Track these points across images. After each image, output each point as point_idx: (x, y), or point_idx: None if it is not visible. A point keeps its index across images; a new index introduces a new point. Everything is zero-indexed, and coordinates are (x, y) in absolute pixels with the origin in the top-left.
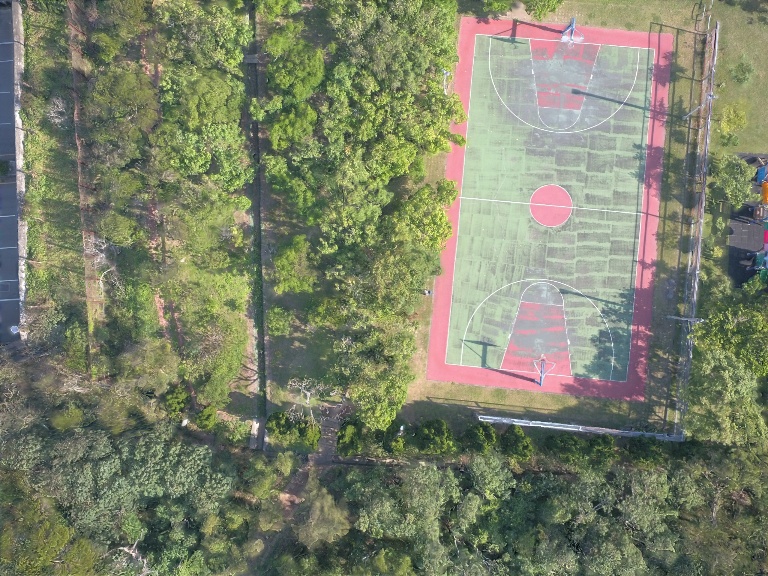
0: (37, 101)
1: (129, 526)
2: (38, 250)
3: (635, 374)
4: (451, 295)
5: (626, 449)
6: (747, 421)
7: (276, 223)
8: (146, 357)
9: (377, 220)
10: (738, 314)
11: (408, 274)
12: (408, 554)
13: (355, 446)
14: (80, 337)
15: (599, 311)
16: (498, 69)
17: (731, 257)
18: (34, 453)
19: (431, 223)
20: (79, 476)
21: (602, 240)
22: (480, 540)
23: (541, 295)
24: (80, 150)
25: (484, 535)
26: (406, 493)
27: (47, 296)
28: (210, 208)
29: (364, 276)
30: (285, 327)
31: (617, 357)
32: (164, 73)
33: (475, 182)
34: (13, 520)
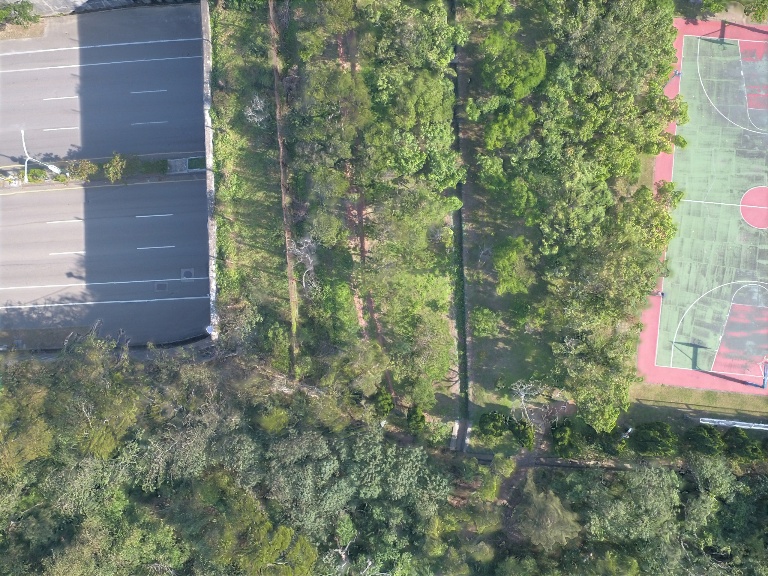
0: (231, 100)
1: (344, 528)
2: (230, 250)
3: None
4: (661, 297)
5: None
6: None
7: (479, 224)
8: (367, 358)
9: None
10: None
11: (643, 276)
12: None
13: (576, 448)
14: (283, 337)
15: None
16: (707, 70)
17: None
18: (249, 454)
19: (658, 224)
20: (299, 477)
21: None
22: (706, 543)
23: (752, 297)
24: (282, 149)
25: (709, 538)
26: (636, 495)
27: (242, 296)
28: (429, 208)
29: (592, 277)
30: (494, 328)
31: None
32: (362, 72)
33: (684, 183)
34: (207, 521)
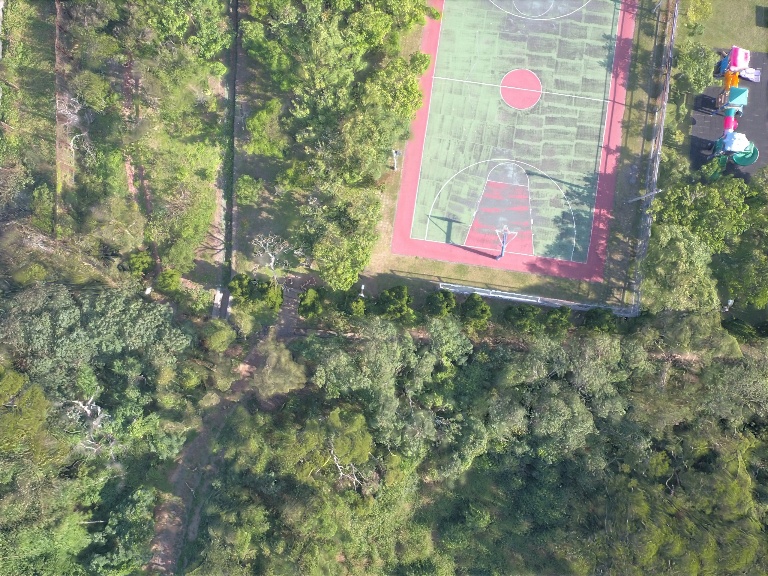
0: None
1: (85, 380)
2: (11, 115)
3: (595, 256)
4: (419, 171)
5: (583, 324)
6: (700, 289)
7: (250, 95)
8: (112, 208)
9: (349, 87)
10: (696, 189)
11: (376, 132)
12: (363, 415)
13: (316, 307)
14: (48, 197)
15: (563, 193)
16: None
17: (693, 146)
18: None
19: (402, 88)
20: (37, 323)
21: (569, 125)
22: (435, 403)
23: (507, 175)
24: (59, 12)
25: (439, 399)
26: (364, 350)
27: (17, 160)
28: (185, 67)
29: (333, 136)
30: (253, 194)
31: (579, 239)
32: None
33: (448, 63)
34: None
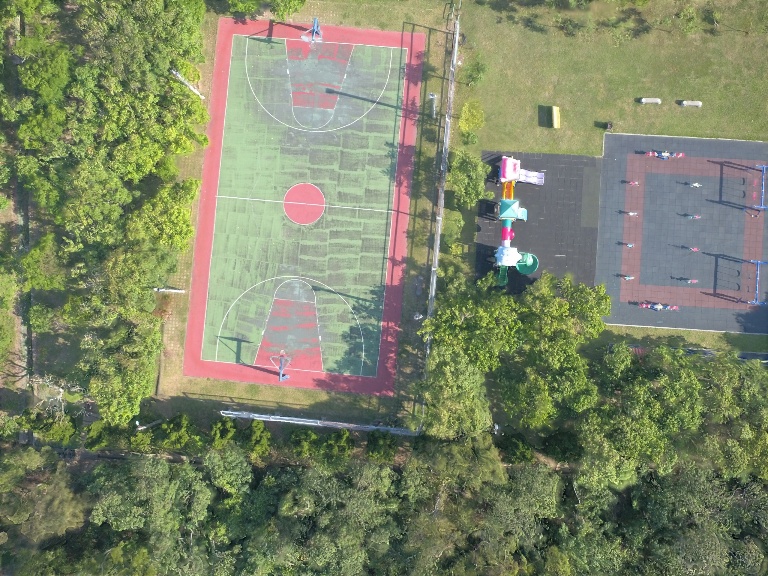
0: None
1: None
2: None
3: (385, 370)
4: (207, 292)
5: (367, 443)
6: (463, 416)
7: (42, 222)
8: None
9: (121, 219)
10: (462, 310)
11: (136, 272)
12: (148, 546)
13: (100, 441)
14: None
15: (350, 308)
16: (254, 69)
17: (478, 254)
18: None
19: (167, 222)
20: None
21: (354, 238)
22: (216, 533)
23: (294, 292)
24: None
25: (221, 528)
26: (139, 487)
27: None
28: None
29: (100, 274)
30: (44, 324)
31: (367, 353)
32: None
33: (231, 181)
34: None
